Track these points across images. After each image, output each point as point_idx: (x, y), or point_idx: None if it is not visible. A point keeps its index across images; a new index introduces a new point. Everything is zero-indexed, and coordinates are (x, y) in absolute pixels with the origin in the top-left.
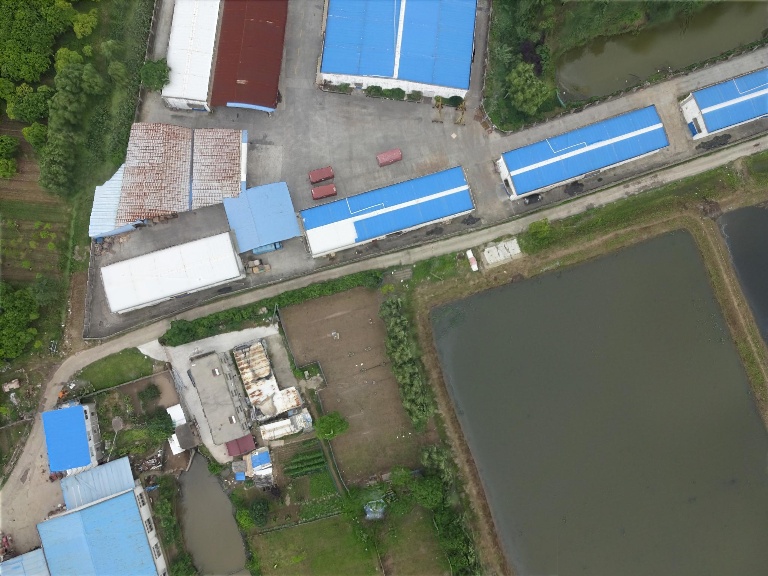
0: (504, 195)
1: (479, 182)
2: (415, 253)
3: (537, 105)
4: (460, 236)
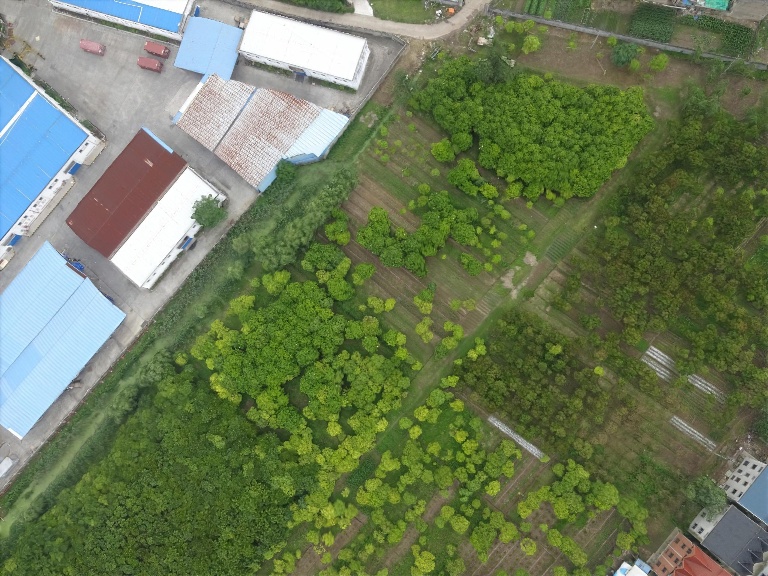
0: None
1: None
2: None
3: None
4: None
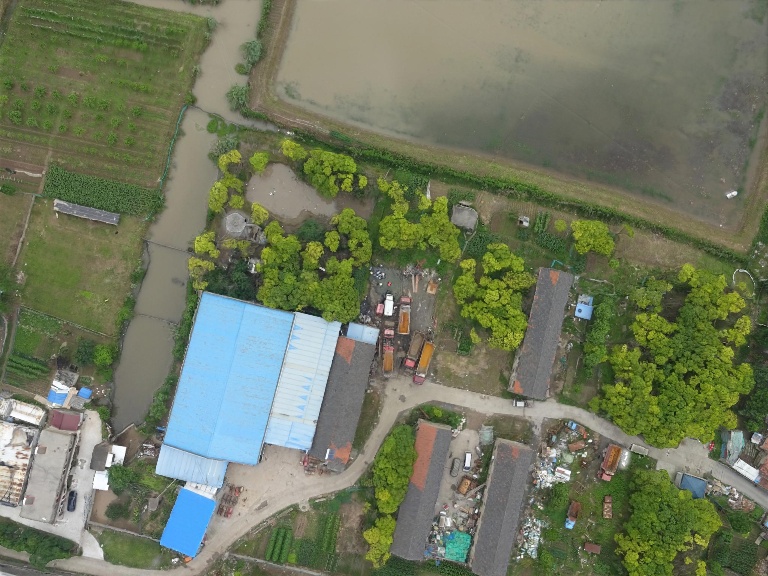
0: None
1: None
2: None
3: None
4: None
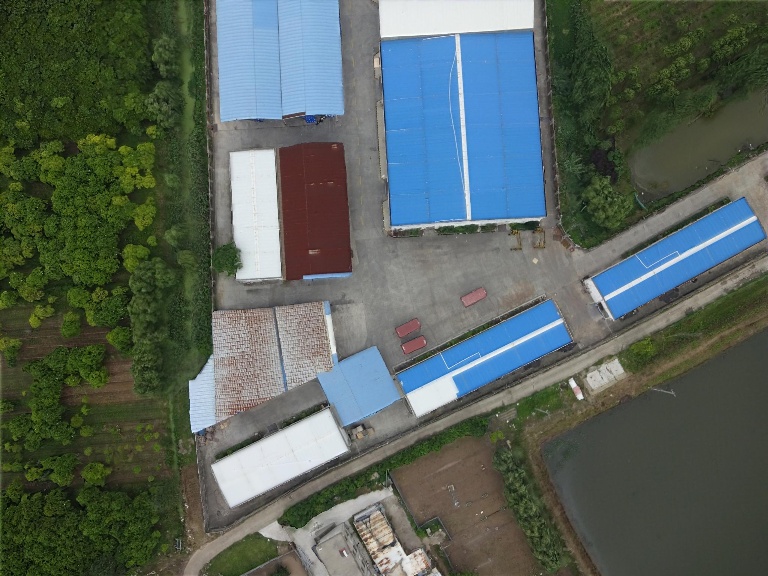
0: (597, 315)
1: (569, 305)
2: (516, 391)
3: (620, 220)
4: (559, 366)
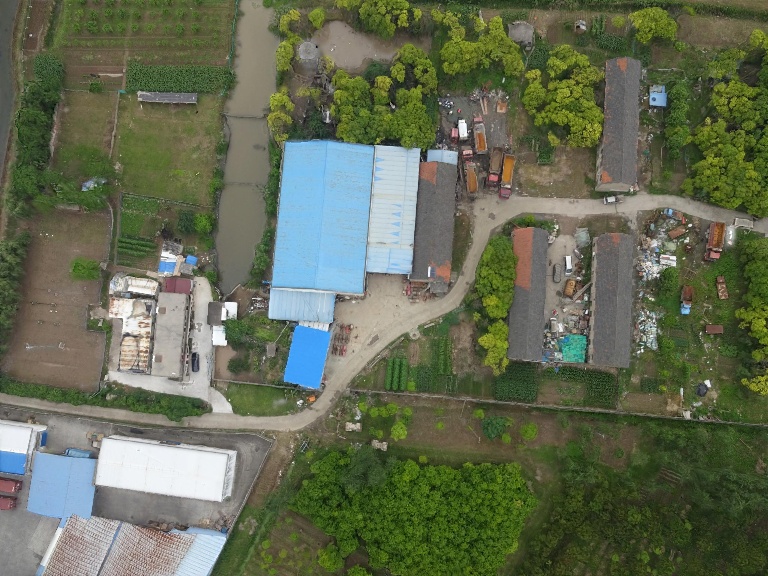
0: None
1: None
2: None
3: None
4: None
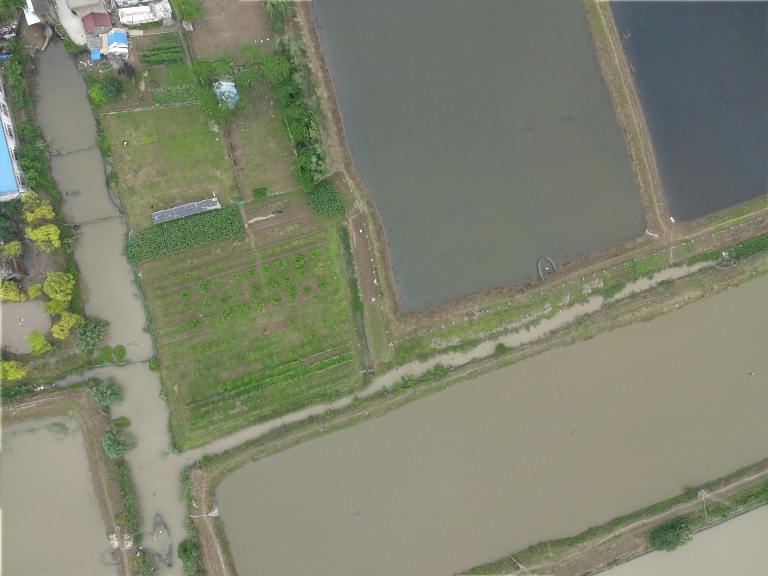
0: None
1: None
2: None
3: None
4: None
